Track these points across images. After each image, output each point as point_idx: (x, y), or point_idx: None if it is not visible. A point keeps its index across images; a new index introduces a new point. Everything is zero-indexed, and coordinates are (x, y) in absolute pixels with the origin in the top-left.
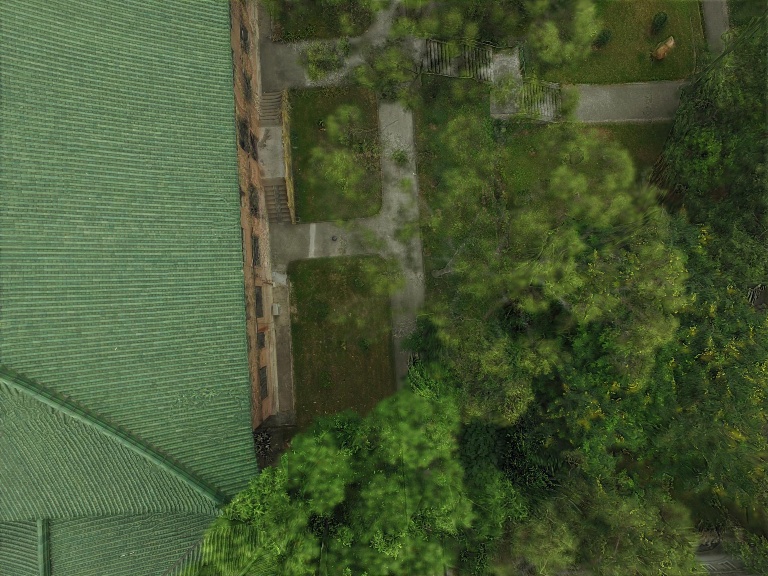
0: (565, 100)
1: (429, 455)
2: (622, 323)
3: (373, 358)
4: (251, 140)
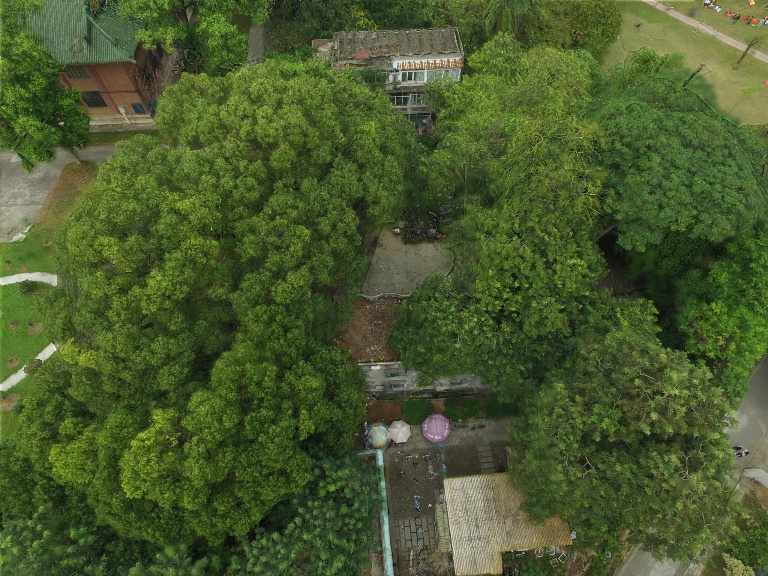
0: None
1: None
2: None
3: None
4: None
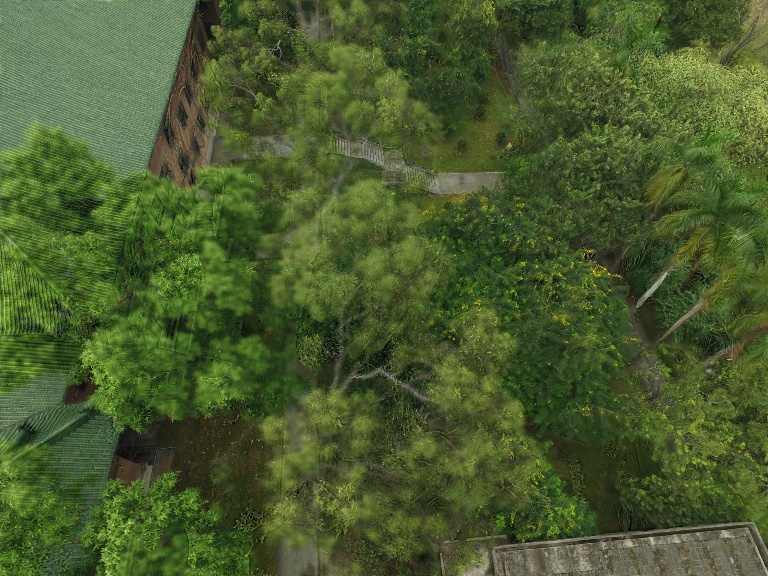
0: (441, 181)
1: (311, 425)
2: (473, 274)
3: (266, 335)
4: (191, 175)
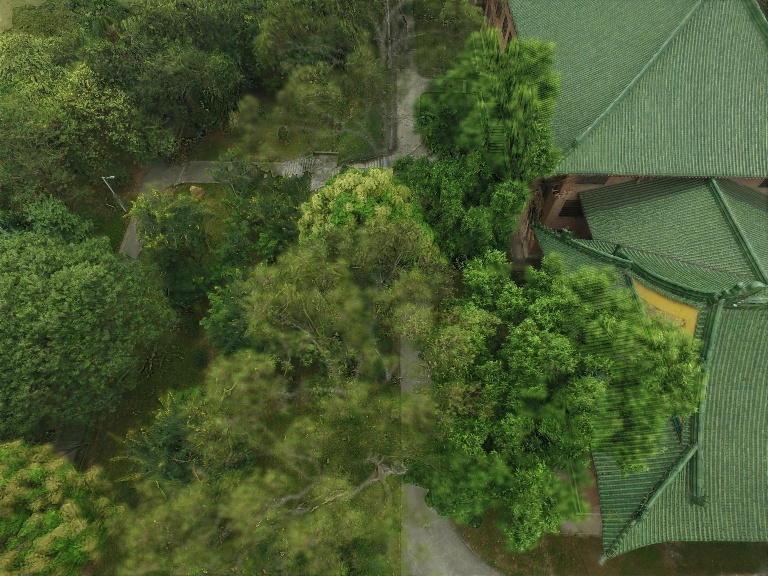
0: None
1: None
2: None
3: None
4: None
